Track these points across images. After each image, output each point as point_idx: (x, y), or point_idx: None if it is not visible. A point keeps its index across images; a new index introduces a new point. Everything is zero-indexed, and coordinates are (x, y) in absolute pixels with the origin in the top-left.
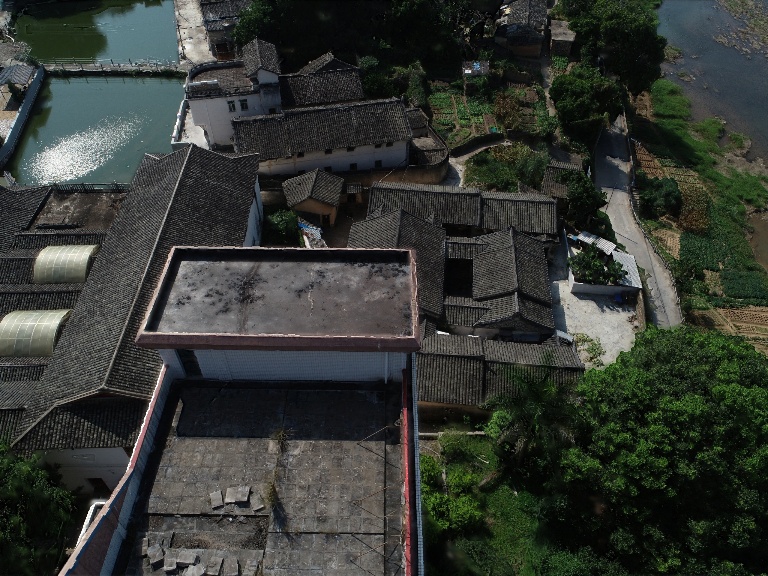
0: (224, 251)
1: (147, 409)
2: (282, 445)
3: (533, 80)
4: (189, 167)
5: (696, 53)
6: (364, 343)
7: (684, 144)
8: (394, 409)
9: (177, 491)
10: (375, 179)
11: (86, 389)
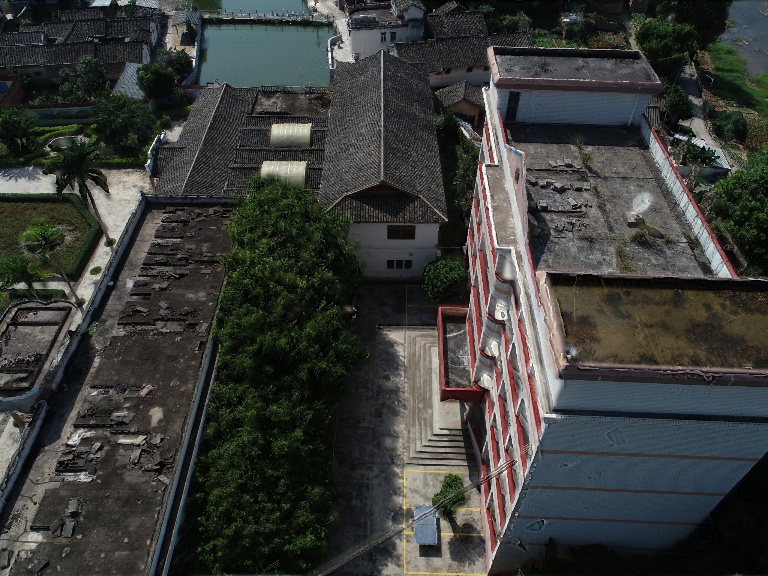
0: (521, 50)
1: (408, 199)
2: (579, 147)
3: (619, 30)
4: (385, 64)
5: (746, 24)
6: (631, 85)
7: (743, 91)
8: (638, 137)
9: (528, 161)
10: None
11: (367, 184)
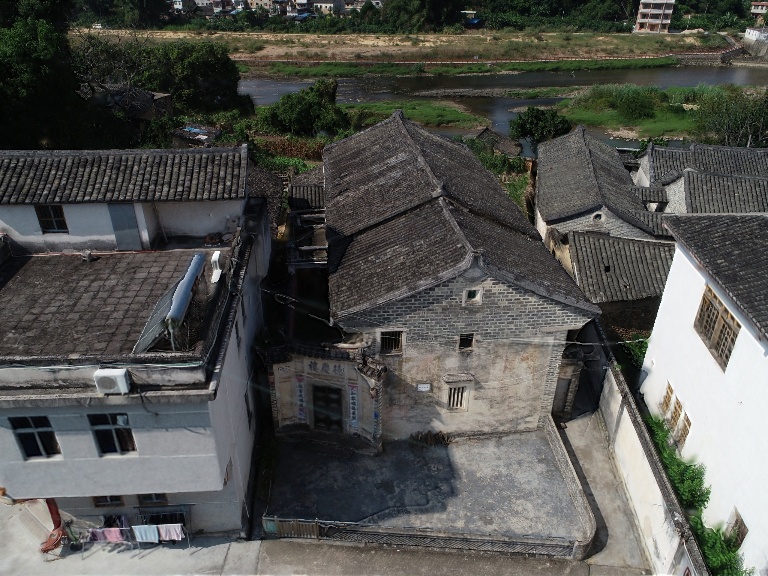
0: None
1: None
2: None
3: None
4: None
5: None
6: None
7: None
8: None
9: None
10: None
11: None
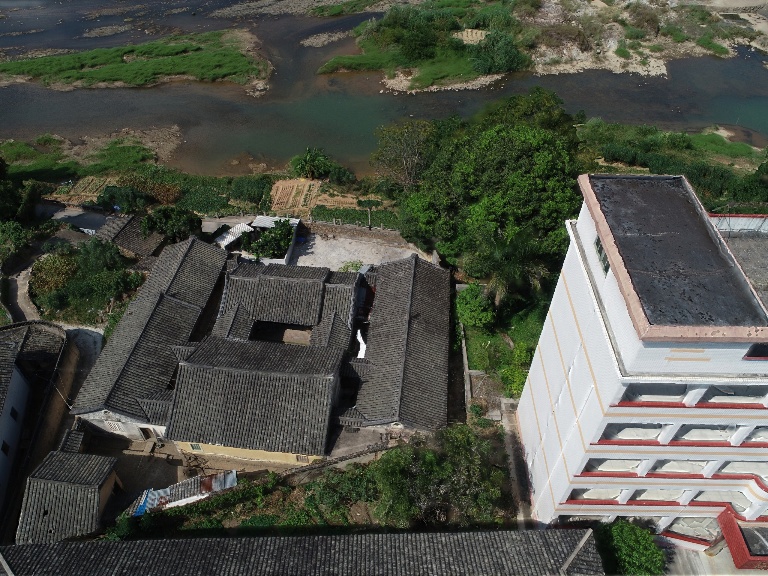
0: None
1: None
2: None
3: None
4: None
5: None
6: None
7: (36, 172)
8: None
9: None
10: (50, 419)
11: None
